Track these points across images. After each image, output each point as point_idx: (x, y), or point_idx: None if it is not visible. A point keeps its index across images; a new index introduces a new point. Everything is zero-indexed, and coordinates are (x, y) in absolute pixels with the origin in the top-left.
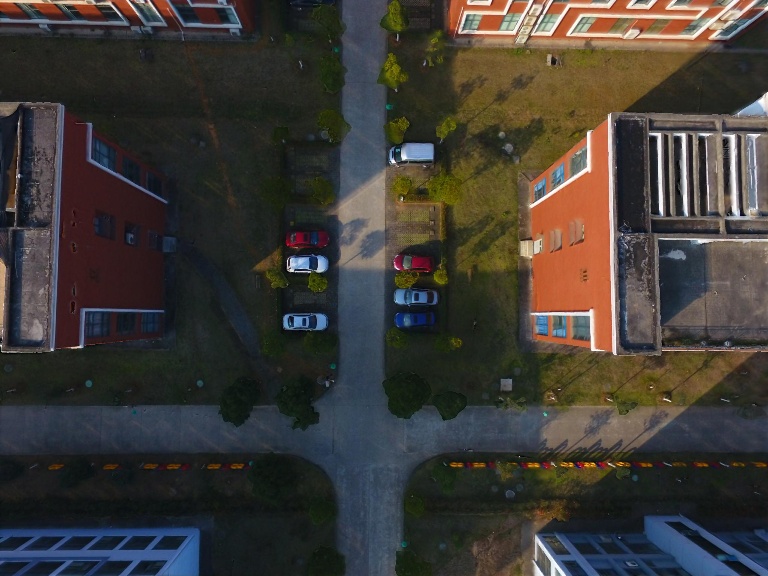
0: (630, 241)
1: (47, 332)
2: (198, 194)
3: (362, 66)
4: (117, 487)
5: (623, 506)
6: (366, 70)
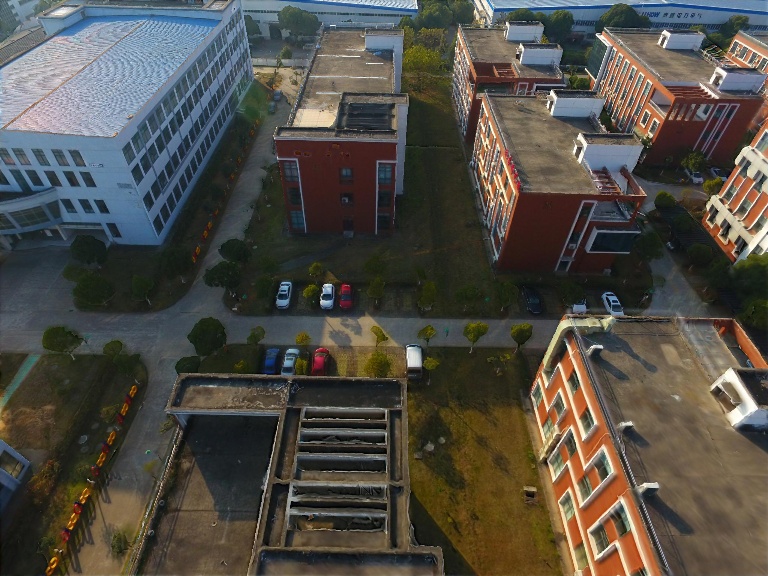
0: (283, 392)
1: (283, 136)
2: (382, 247)
3: (488, 331)
4: (203, 215)
5: (3, 566)
6: (485, 334)
